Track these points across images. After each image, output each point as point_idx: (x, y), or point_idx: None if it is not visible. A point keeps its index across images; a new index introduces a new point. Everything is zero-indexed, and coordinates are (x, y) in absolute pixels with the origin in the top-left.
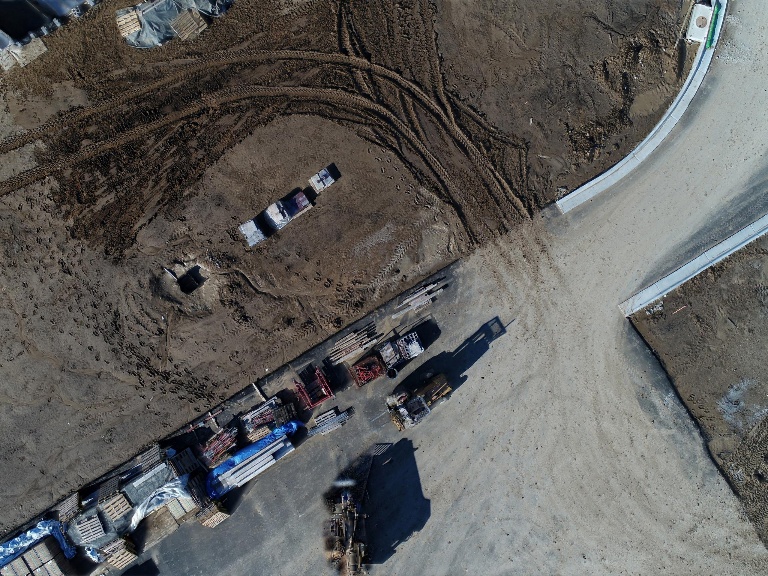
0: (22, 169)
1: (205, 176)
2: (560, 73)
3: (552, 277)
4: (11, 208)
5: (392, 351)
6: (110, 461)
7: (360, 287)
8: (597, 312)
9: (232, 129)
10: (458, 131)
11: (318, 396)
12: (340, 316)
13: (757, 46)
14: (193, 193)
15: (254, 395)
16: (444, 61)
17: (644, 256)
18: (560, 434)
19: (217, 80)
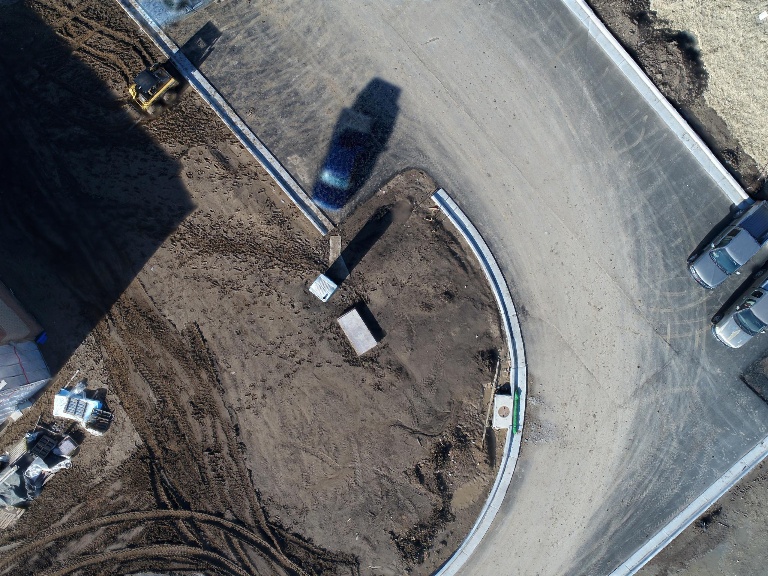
0: None
1: None
2: (376, 485)
3: None
4: None
5: None
6: None
7: None
8: None
9: None
10: (288, 560)
11: None
12: None
13: (563, 422)
14: None
15: None
16: (262, 495)
17: None
18: None
19: (45, 558)
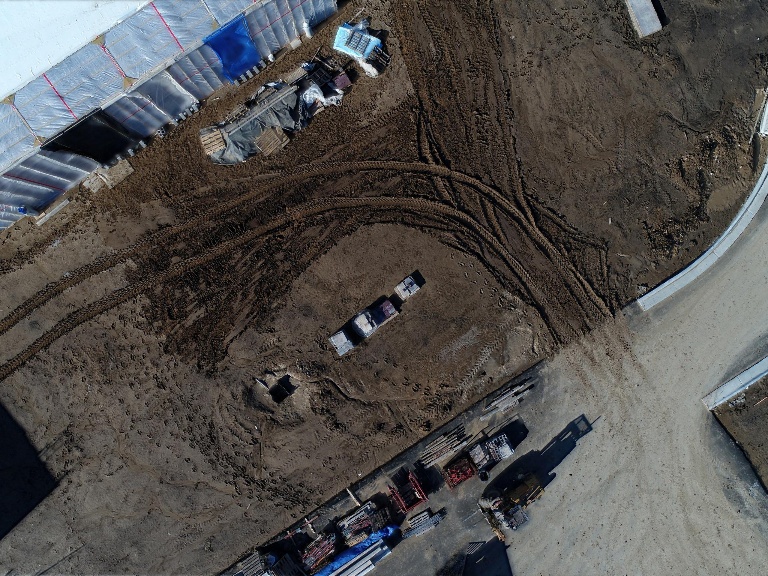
0: (114, 289)
1: (292, 288)
2: (637, 172)
3: (635, 374)
4: (105, 327)
5: (482, 452)
6: (211, 569)
7: (448, 390)
8: (681, 406)
9: (317, 241)
10: (539, 234)
11: (411, 499)
12: (429, 419)
13: None
14: (281, 305)
15: (348, 500)
16: (523, 165)
17: (725, 350)
18: (648, 527)
19: (301, 193)
